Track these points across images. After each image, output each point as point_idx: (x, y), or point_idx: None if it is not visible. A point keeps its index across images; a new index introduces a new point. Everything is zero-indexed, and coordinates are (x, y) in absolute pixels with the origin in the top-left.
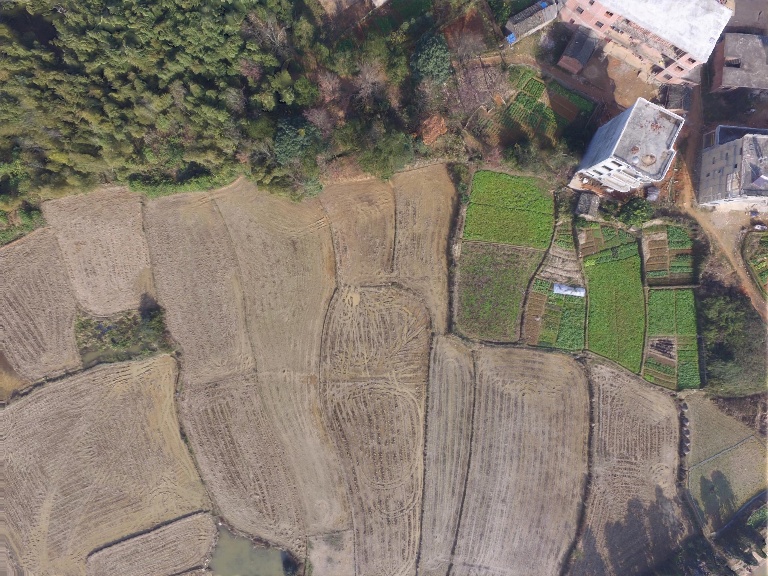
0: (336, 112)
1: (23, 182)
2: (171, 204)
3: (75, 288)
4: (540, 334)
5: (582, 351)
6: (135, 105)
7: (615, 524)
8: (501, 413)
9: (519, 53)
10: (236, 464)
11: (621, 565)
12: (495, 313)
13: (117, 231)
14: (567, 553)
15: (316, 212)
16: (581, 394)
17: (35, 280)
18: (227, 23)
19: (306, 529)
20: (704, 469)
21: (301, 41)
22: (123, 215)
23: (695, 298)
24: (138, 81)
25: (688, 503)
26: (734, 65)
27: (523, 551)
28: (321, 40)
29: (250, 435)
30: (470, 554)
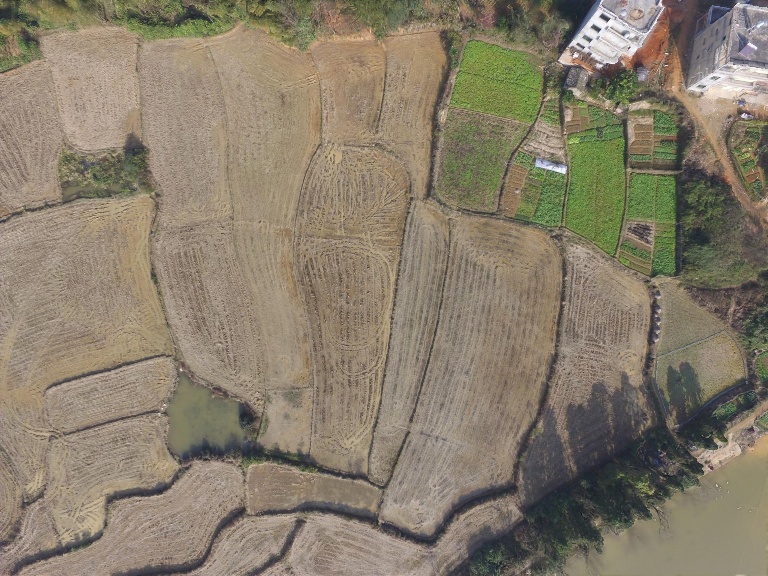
0: None
1: (24, 6)
2: (166, 47)
3: (63, 121)
4: (518, 207)
5: (559, 228)
6: None
7: (578, 407)
8: (472, 284)
9: None
10: (203, 310)
11: (580, 450)
12: (475, 182)
13: (111, 69)
14: (527, 432)
15: (307, 68)
16: (554, 273)
17: (25, 110)
18: None
19: (266, 382)
20: (672, 359)
21: None
22: (118, 55)
23: (677, 185)
24: None
25: (653, 392)
26: None
27: (482, 426)
28: None
29: (220, 282)
30: (428, 423)
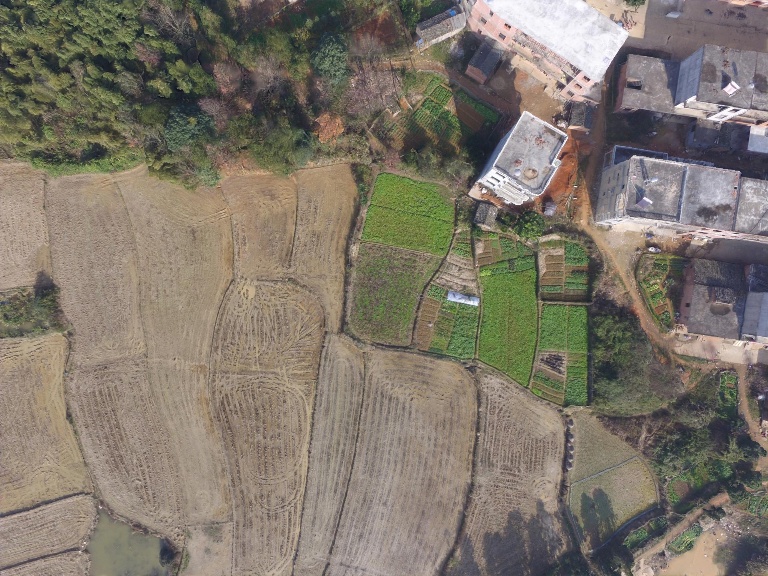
0: (244, 104)
1: None
2: (73, 184)
3: None
4: (432, 340)
5: (472, 360)
6: (33, 82)
7: (494, 535)
8: (388, 416)
9: (429, 59)
10: (120, 448)
11: None
12: (388, 316)
13: (18, 207)
14: (444, 560)
15: (218, 202)
16: (469, 403)
17: None
18: (126, 7)
19: (186, 518)
20: (586, 486)
21: (208, 31)
22: (25, 191)
23: (588, 315)
24: (36, 58)
25: (568, 519)
26: (636, 87)
27: (401, 555)
28: (234, 32)
29: (136, 420)
30: (347, 555)
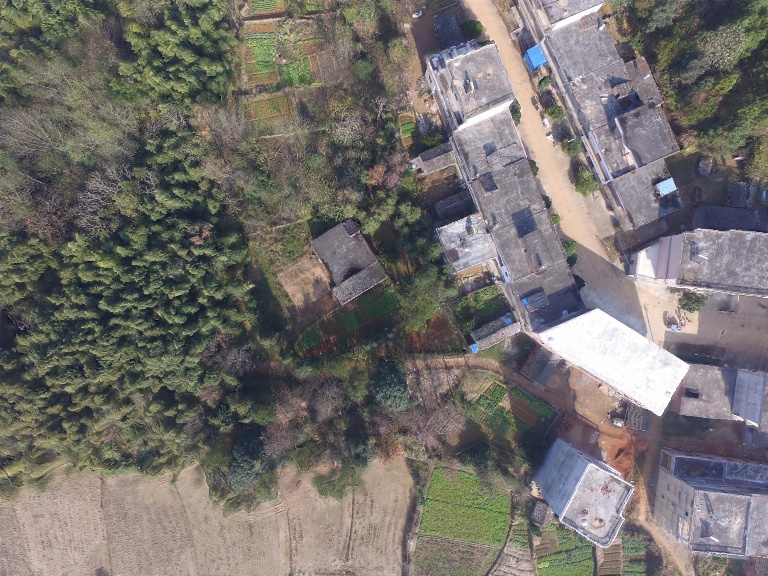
0: (298, 403)
1: None
2: (130, 483)
3: (31, 560)
4: None
5: None
6: (95, 414)
7: None
8: None
9: (482, 357)
10: None
11: None
12: None
13: (75, 506)
14: None
15: None
16: None
17: None
18: (188, 353)
19: None
20: None
21: (265, 347)
22: (82, 490)
23: None
24: (98, 398)
25: None
26: (693, 394)
27: None
28: (287, 331)
29: None
30: None
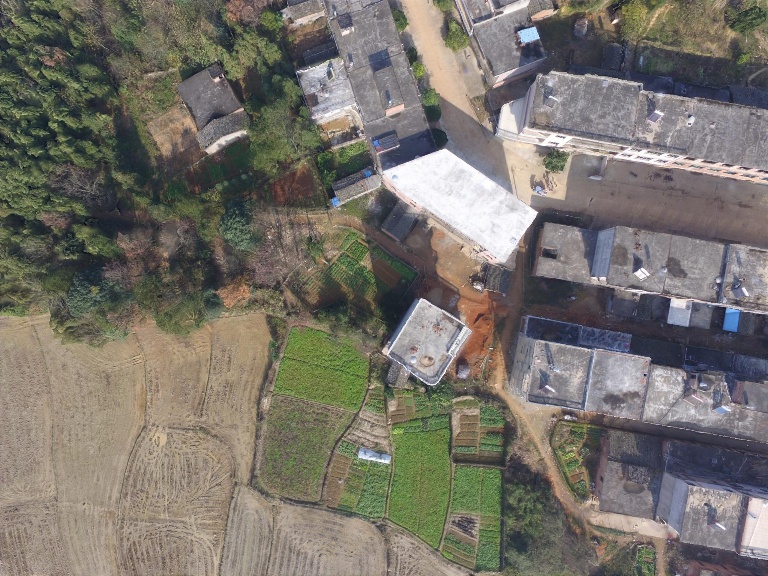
0: (160, 253)
1: None
2: None
3: None
4: (341, 497)
5: (382, 519)
6: None
7: None
8: (296, 571)
9: (346, 214)
10: None
11: None
12: (298, 471)
13: None
14: None
15: (133, 348)
16: (379, 561)
17: None
18: (33, 175)
19: None
20: None
21: (123, 186)
22: None
23: (502, 478)
24: None
25: None
26: (551, 255)
27: None
28: (153, 180)
29: (44, 563)
30: None
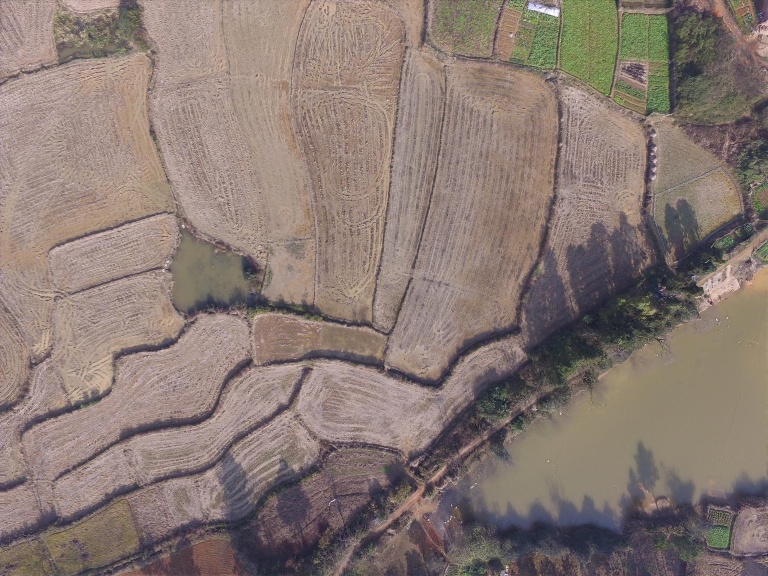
0: None
1: None
2: None
3: None
4: (513, 51)
5: (553, 71)
6: None
7: (578, 248)
8: (470, 130)
9: None
10: (203, 166)
11: (582, 290)
12: (469, 27)
13: None
14: (528, 275)
15: None
16: (550, 116)
17: None
18: None
19: (268, 235)
20: (669, 197)
21: None
22: None
23: (668, 24)
24: None
25: (652, 230)
26: None
27: (484, 270)
28: None
29: (219, 137)
30: (431, 269)
